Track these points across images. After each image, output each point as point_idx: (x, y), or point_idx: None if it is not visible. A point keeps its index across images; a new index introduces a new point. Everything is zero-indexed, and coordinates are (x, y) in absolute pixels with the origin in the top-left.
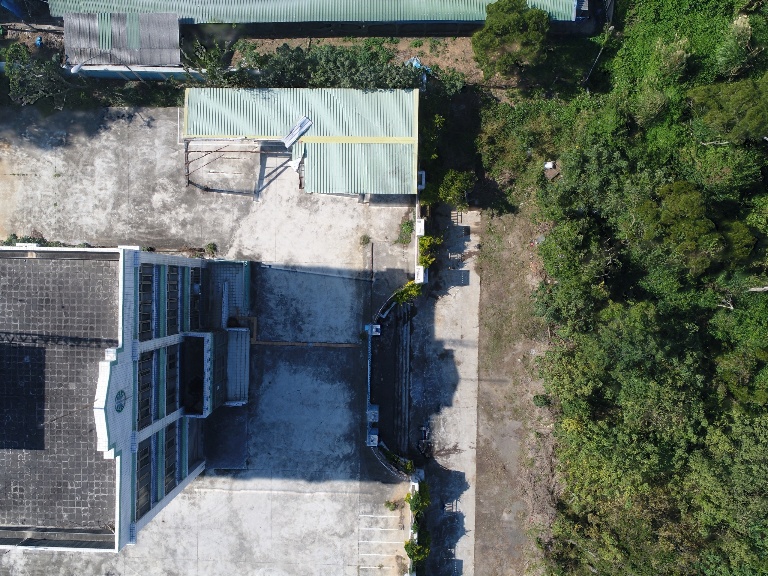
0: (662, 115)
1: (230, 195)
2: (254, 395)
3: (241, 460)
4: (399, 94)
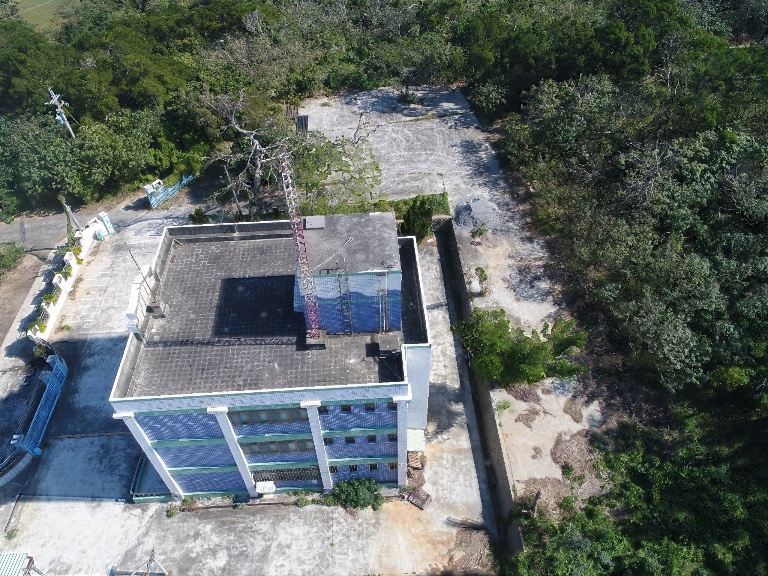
0: None
1: (141, 571)
2: None
3: None
4: None
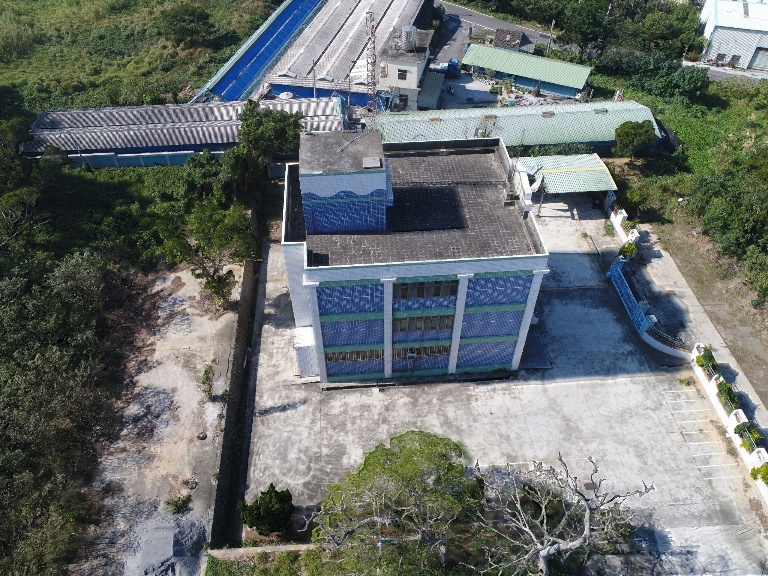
0: (732, 175)
1: None
2: (540, 320)
3: (545, 362)
4: (586, 155)
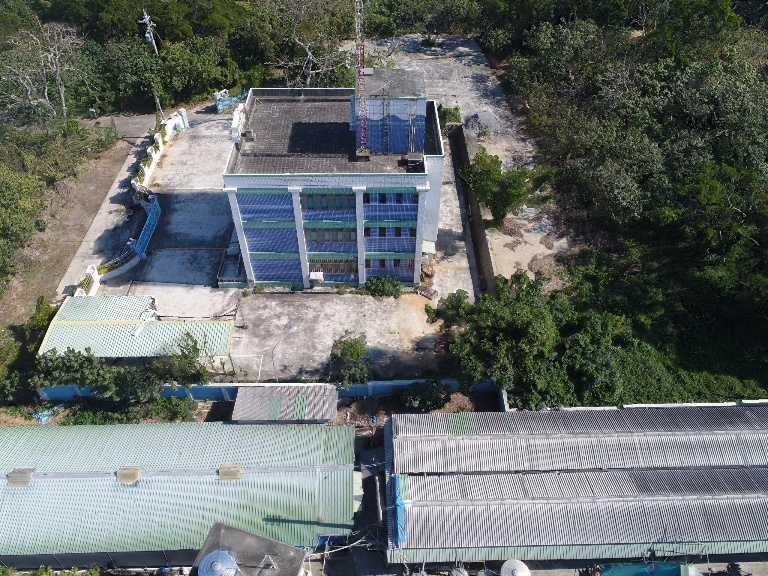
0: None
1: None
2: (231, 226)
3: None
4: None
